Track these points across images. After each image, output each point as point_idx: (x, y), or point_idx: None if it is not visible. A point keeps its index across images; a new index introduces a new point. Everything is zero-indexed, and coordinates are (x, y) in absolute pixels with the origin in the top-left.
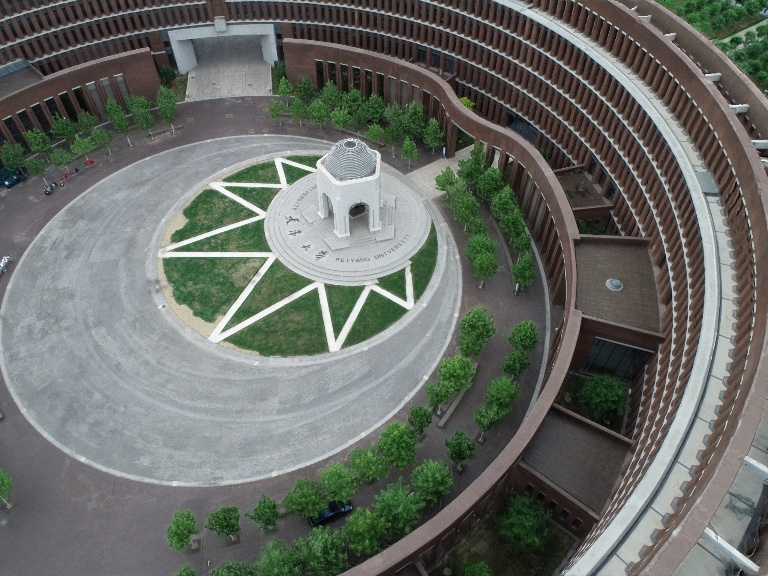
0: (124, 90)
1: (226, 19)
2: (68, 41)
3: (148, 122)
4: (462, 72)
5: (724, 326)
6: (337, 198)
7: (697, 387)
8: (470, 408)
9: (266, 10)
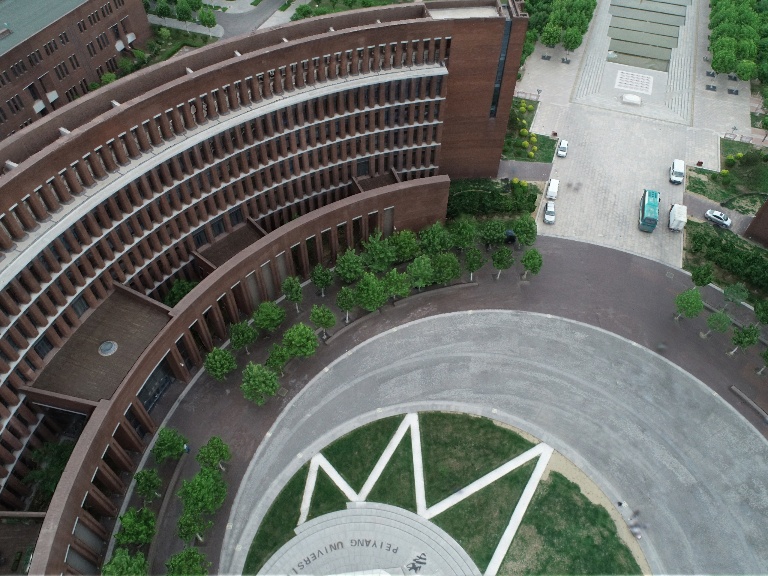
0: None
1: None
2: None
3: None
4: None
5: (112, 179)
6: None
7: (173, 150)
8: None
9: None
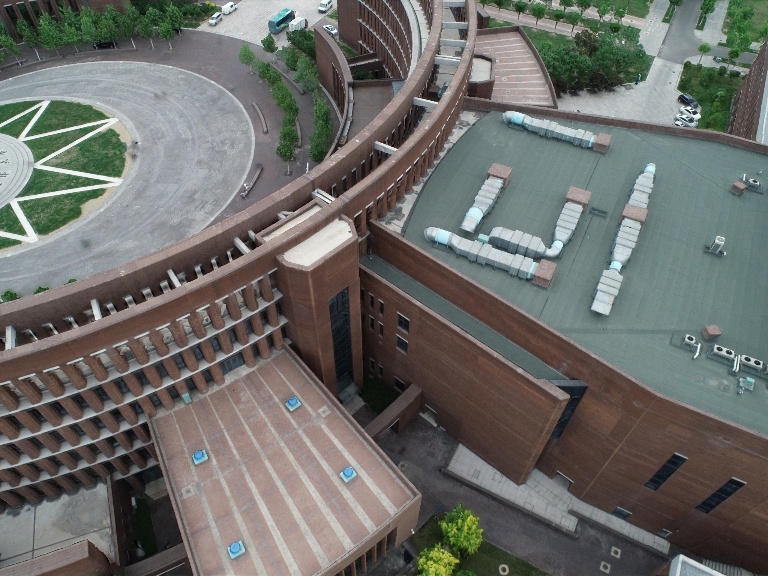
0: None
1: None
2: None
3: None
4: None
5: None
6: None
7: None
8: (3, 64)
9: None
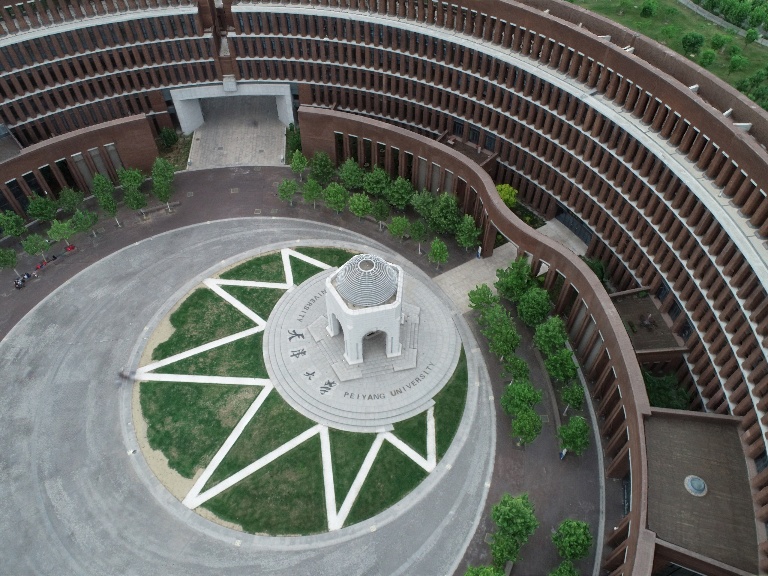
0: (116, 159)
1: (236, 78)
2: (56, 102)
3: (139, 202)
4: (505, 153)
5: None
6: (348, 326)
7: None
8: None
9: (282, 69)
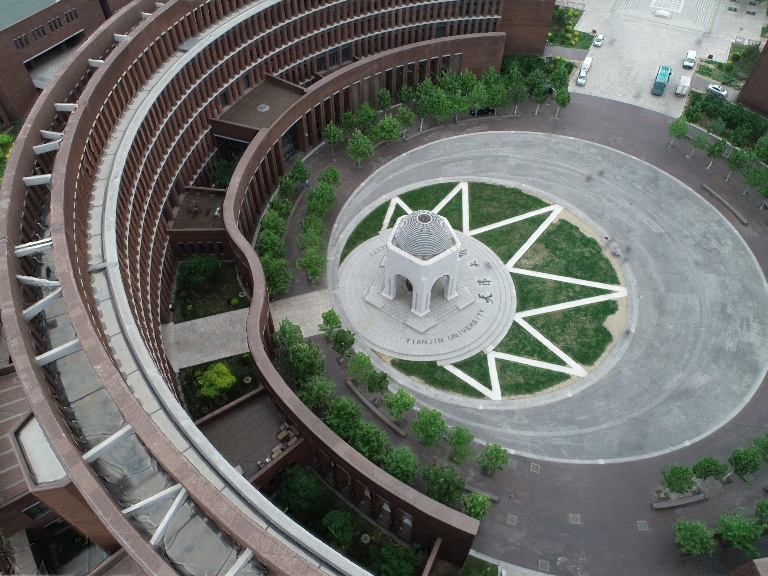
0: None
1: None
2: None
3: None
4: None
5: None
6: None
7: None
8: None
9: None
